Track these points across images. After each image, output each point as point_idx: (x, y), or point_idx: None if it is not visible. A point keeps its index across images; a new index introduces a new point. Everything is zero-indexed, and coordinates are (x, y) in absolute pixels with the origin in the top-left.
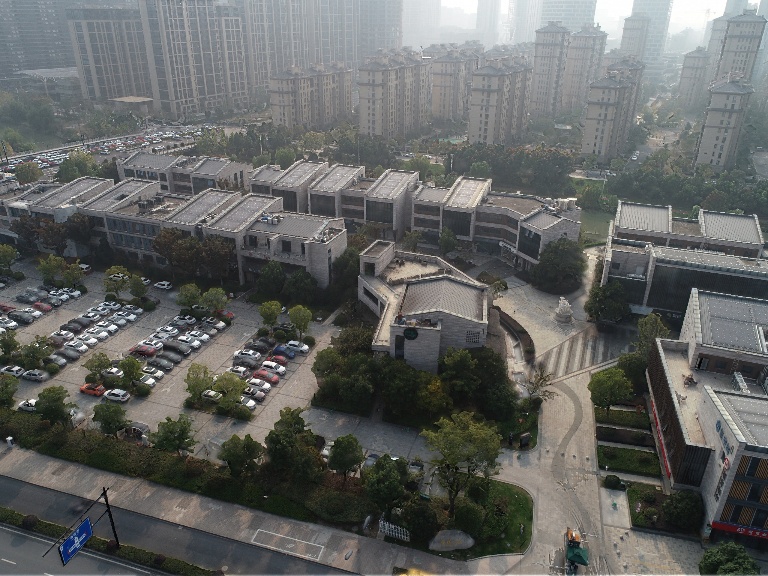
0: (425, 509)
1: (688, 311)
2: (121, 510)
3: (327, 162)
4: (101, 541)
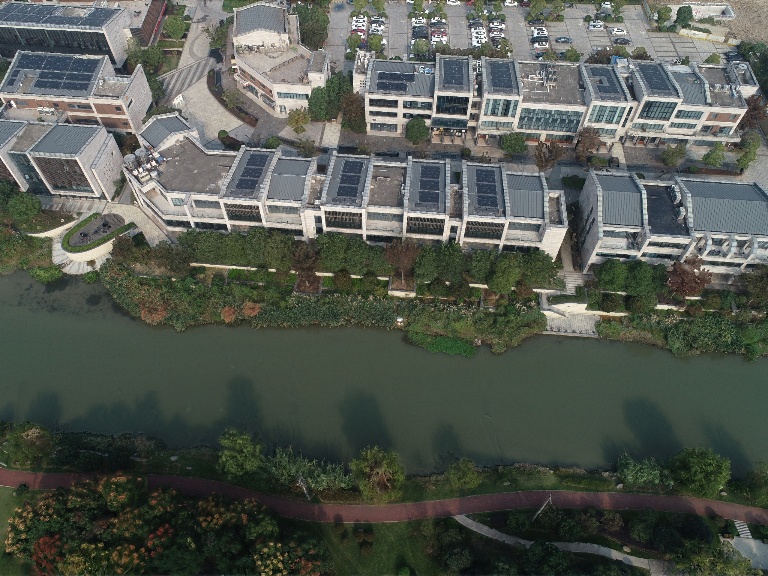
0: None
1: None
2: None
3: (465, 213)
4: None
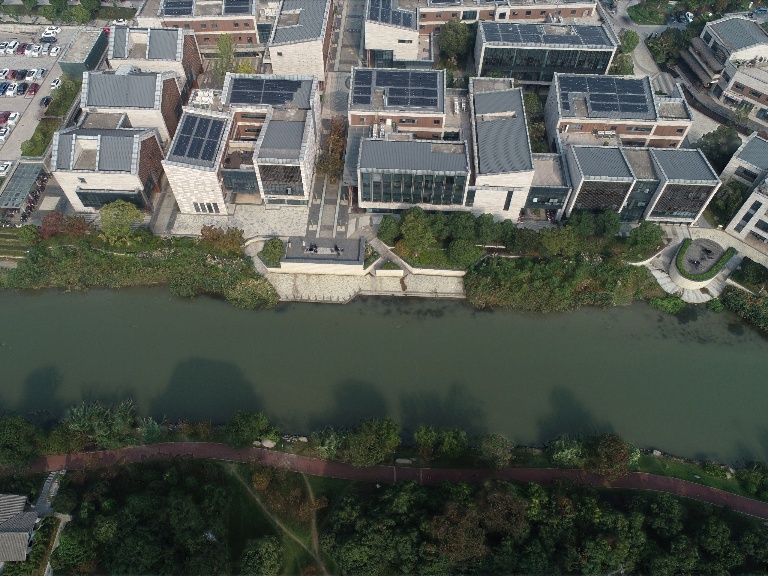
0: None
1: None
2: None
3: None
4: None
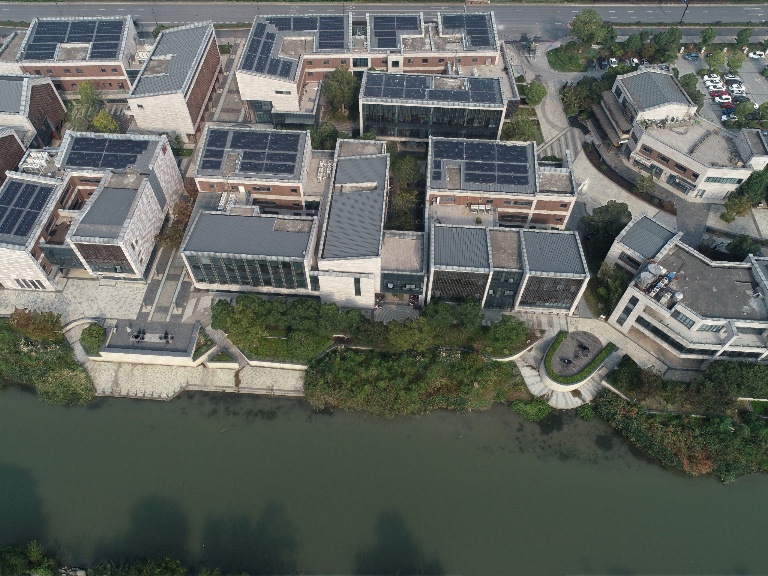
0: None
1: None
2: (697, 35)
3: None
4: (688, 24)
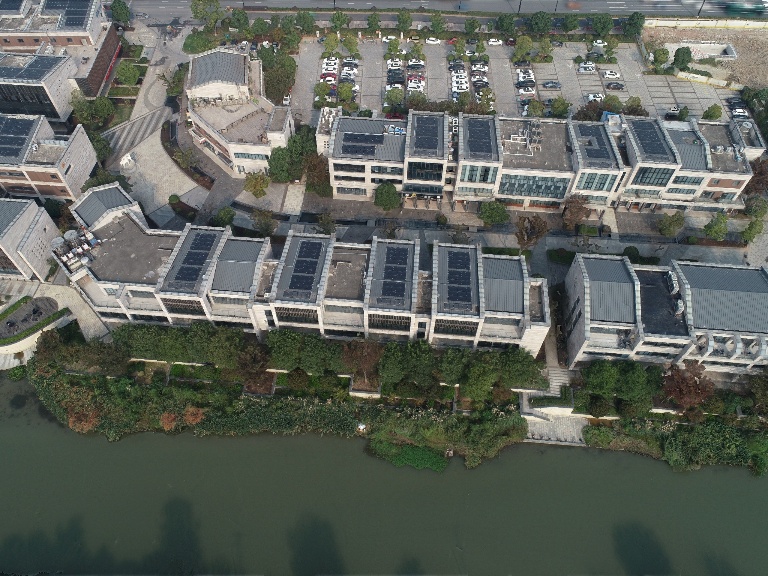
0: (224, 19)
1: (53, 88)
2: None
3: (433, 311)
4: (343, 9)
